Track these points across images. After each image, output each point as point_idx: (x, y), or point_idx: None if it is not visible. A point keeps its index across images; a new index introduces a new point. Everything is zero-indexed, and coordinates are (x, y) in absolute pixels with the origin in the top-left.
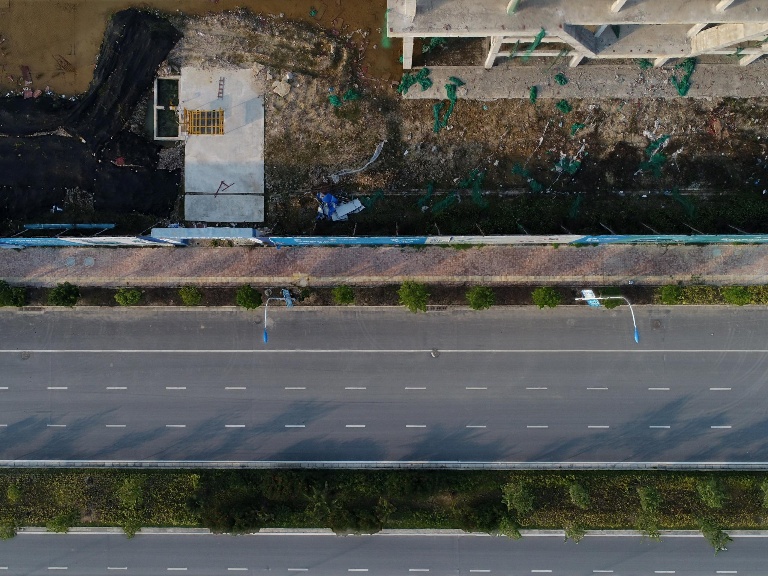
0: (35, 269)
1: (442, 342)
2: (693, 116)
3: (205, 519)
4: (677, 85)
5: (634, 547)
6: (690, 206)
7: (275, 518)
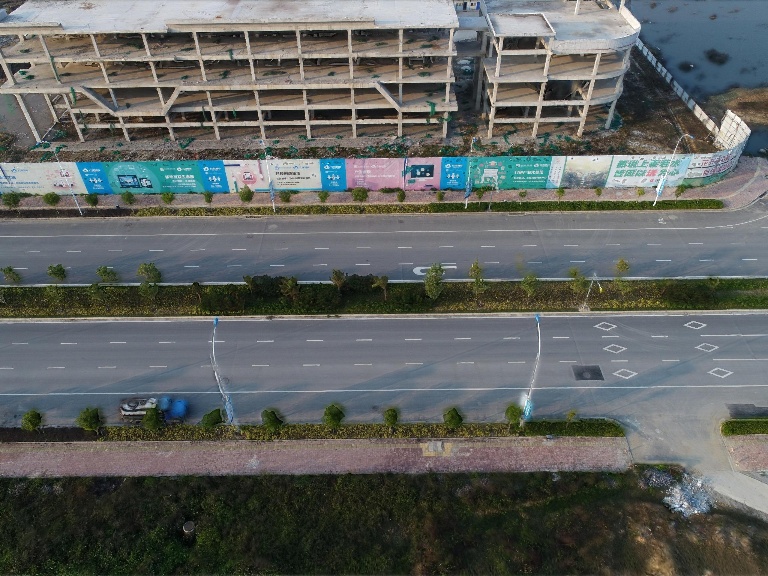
0: None
1: None
2: None
3: None
4: (181, 145)
5: (53, 329)
6: None
7: None
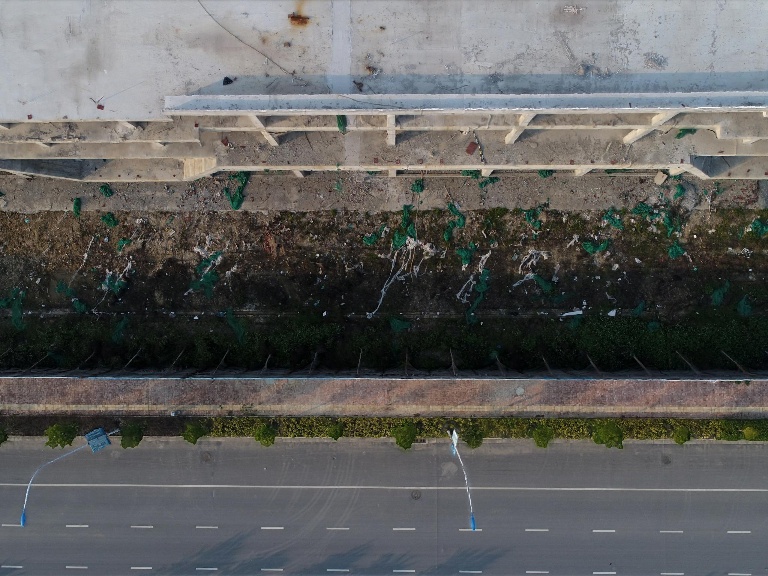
0: None
1: None
2: (247, 231)
3: None
4: (230, 198)
5: None
6: (240, 330)
7: None
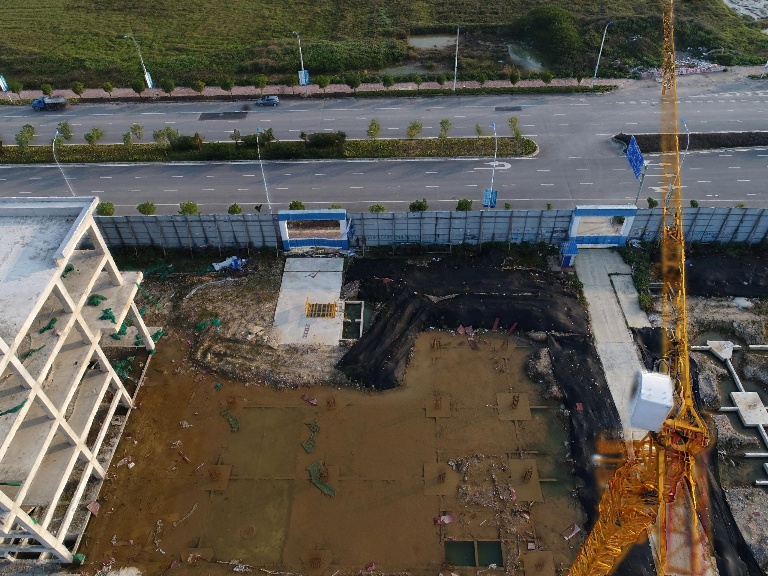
0: None
1: None
2: None
3: None
4: None
5: None
6: None
7: None
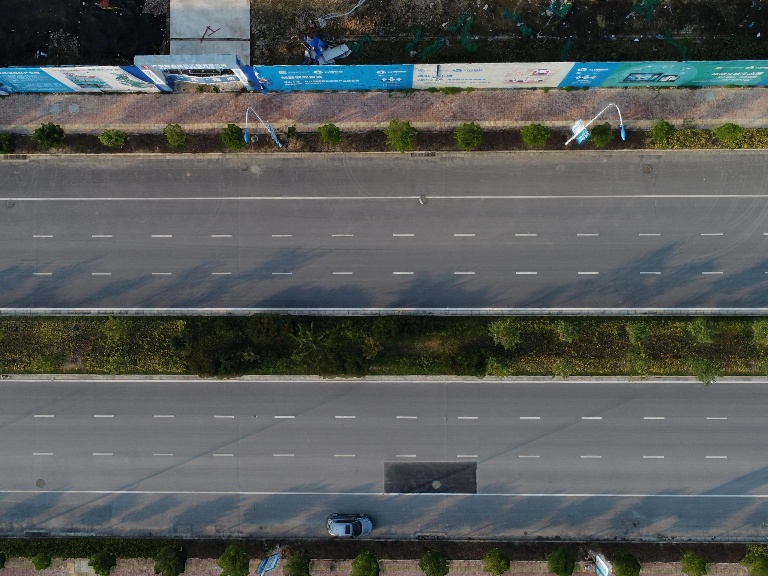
0: (20, 116)
1: (430, 189)
2: None
3: (191, 362)
4: None
5: (623, 394)
6: (683, 48)
7: (261, 364)
